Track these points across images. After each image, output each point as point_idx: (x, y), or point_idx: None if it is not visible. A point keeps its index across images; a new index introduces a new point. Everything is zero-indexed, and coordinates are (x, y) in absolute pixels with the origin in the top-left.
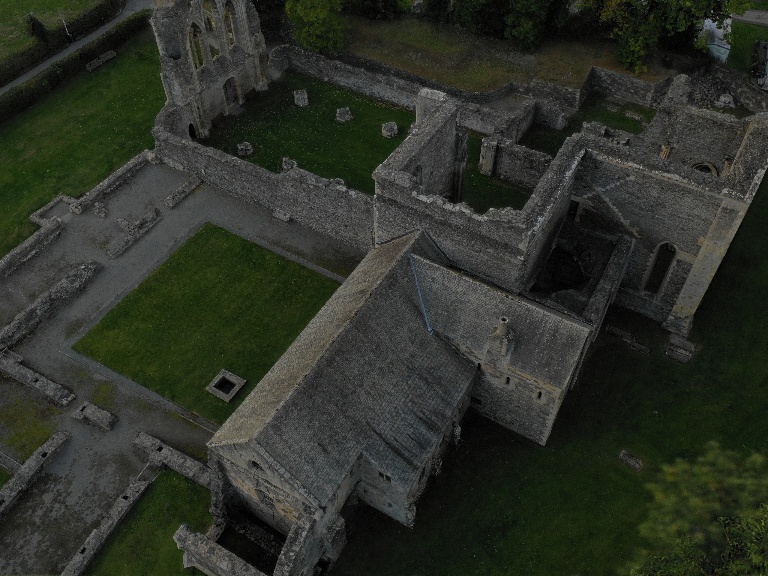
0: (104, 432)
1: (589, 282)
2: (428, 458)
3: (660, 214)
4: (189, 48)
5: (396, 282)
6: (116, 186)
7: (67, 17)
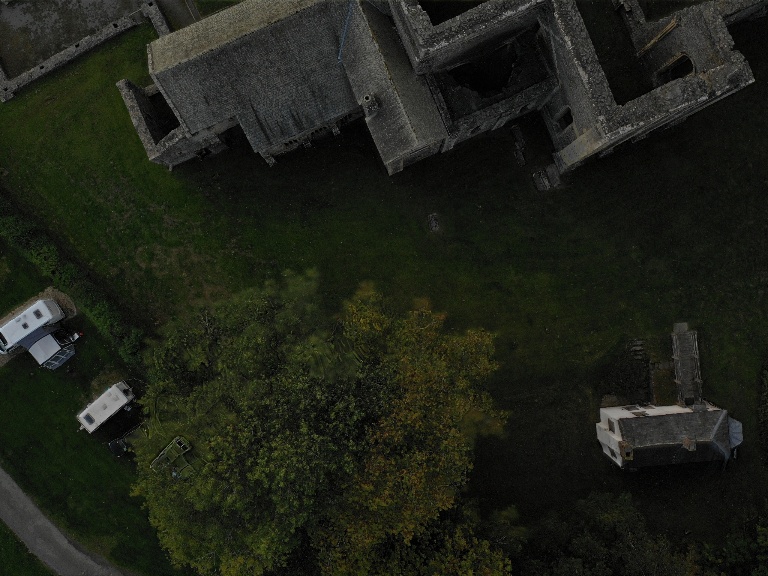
0: None
1: (496, 95)
2: (293, 139)
3: (573, 88)
4: None
5: (328, 11)
6: None
7: None
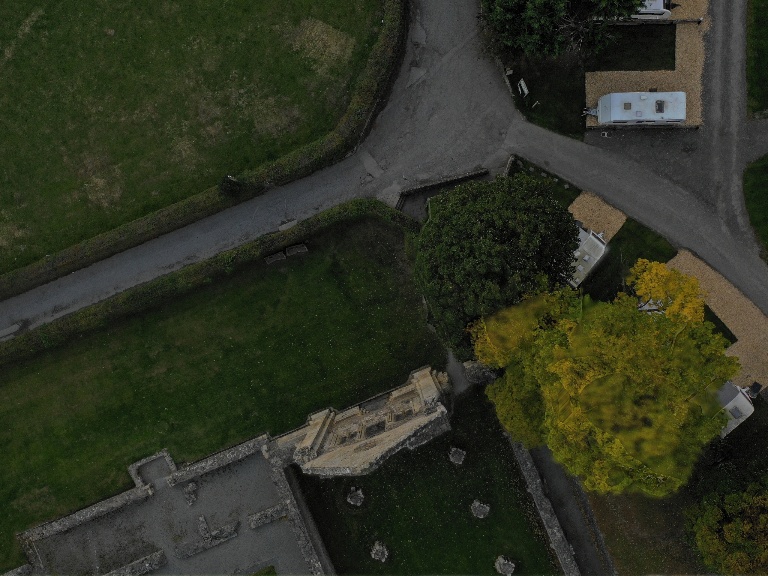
0: None
1: None
2: None
3: None
4: None
5: None
6: None
7: (287, 124)
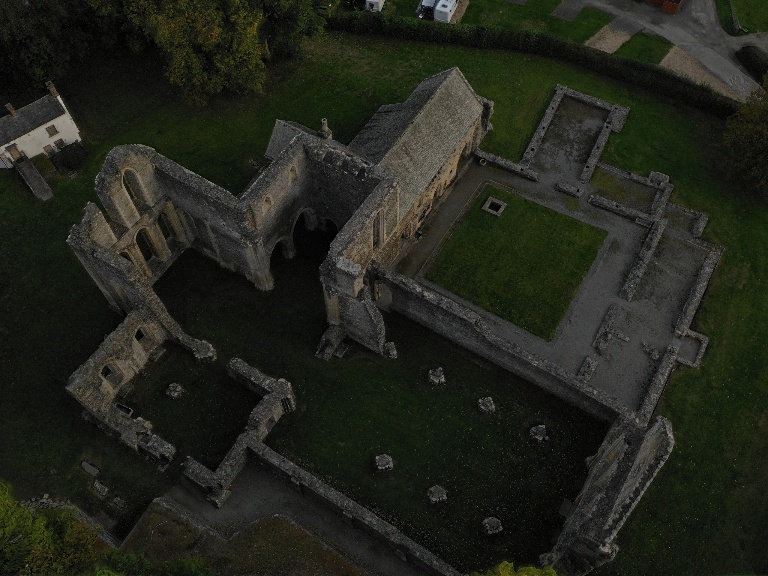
0: None
1: None
2: None
3: None
4: None
5: None
6: None
7: None
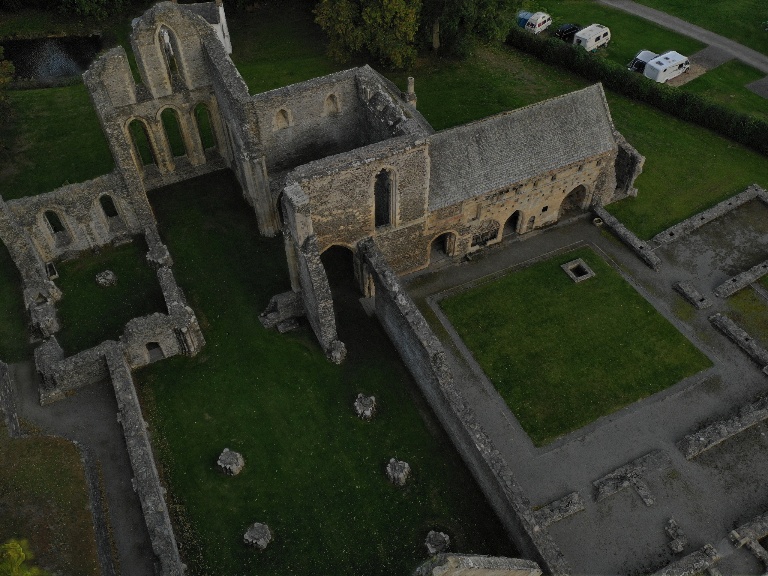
0: None
1: None
2: None
3: None
4: None
5: None
6: None
7: None
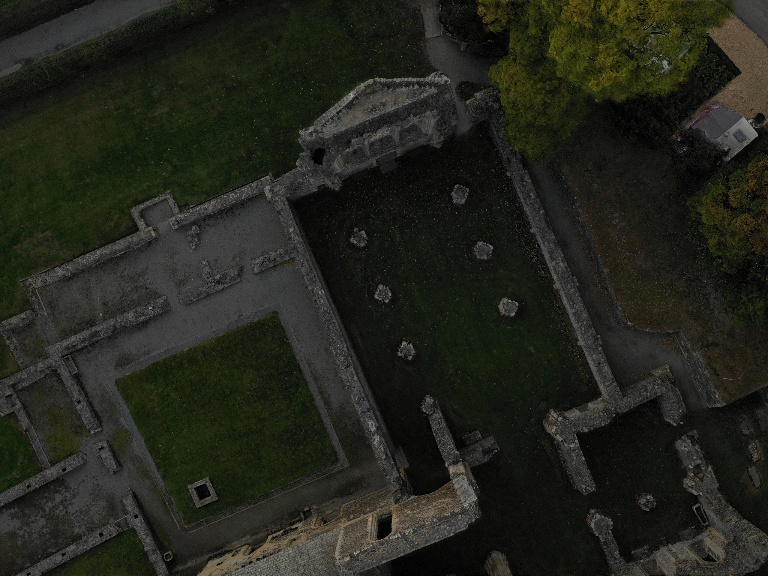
0: (109, 472)
1: None
2: None
3: None
4: (336, 161)
5: None
6: (221, 210)
7: None
